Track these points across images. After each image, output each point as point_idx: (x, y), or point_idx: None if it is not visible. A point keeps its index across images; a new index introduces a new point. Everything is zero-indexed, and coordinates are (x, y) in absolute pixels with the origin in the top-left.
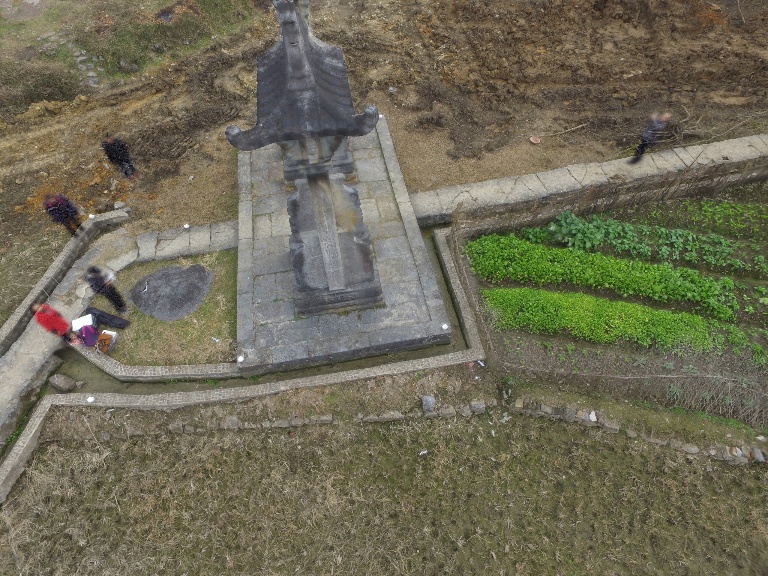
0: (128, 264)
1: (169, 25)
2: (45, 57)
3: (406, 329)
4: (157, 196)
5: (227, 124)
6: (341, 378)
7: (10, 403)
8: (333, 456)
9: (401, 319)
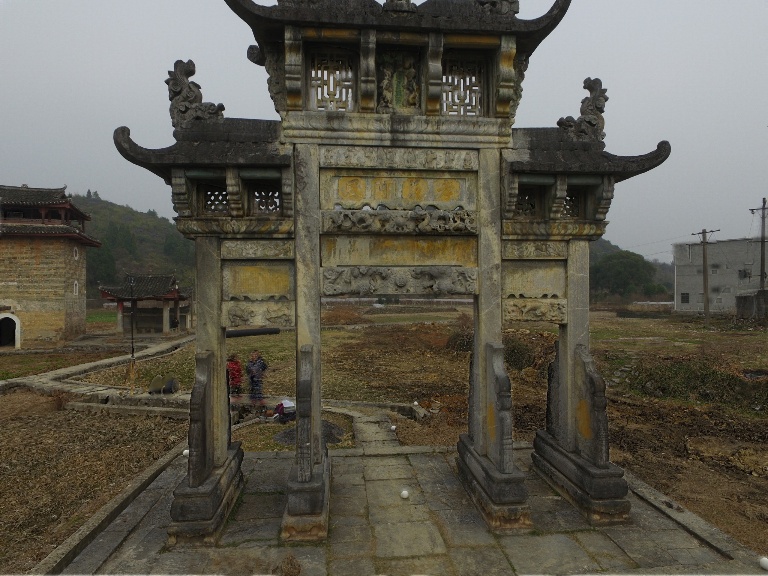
0: (350, 415)
1: (746, 381)
2: (604, 358)
3: (88, 569)
4: (454, 426)
5: (611, 447)
6: (91, 521)
7: (240, 403)
8: (7, 541)
9: (117, 568)
